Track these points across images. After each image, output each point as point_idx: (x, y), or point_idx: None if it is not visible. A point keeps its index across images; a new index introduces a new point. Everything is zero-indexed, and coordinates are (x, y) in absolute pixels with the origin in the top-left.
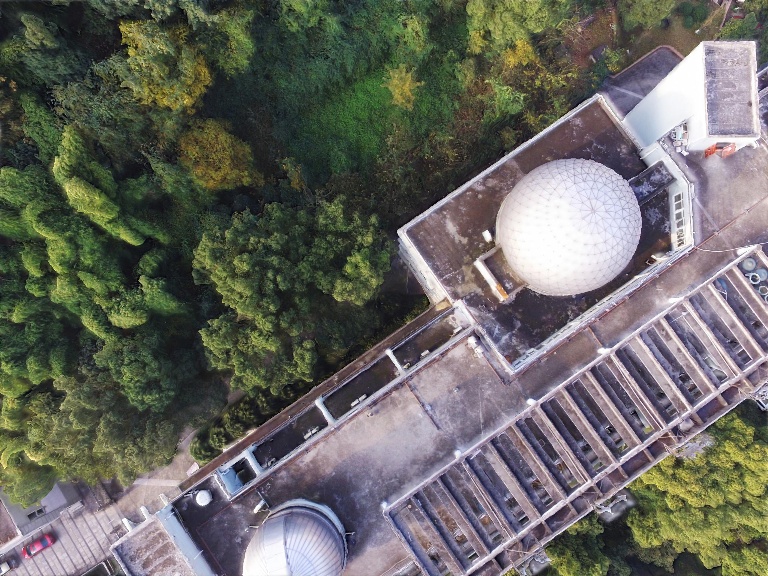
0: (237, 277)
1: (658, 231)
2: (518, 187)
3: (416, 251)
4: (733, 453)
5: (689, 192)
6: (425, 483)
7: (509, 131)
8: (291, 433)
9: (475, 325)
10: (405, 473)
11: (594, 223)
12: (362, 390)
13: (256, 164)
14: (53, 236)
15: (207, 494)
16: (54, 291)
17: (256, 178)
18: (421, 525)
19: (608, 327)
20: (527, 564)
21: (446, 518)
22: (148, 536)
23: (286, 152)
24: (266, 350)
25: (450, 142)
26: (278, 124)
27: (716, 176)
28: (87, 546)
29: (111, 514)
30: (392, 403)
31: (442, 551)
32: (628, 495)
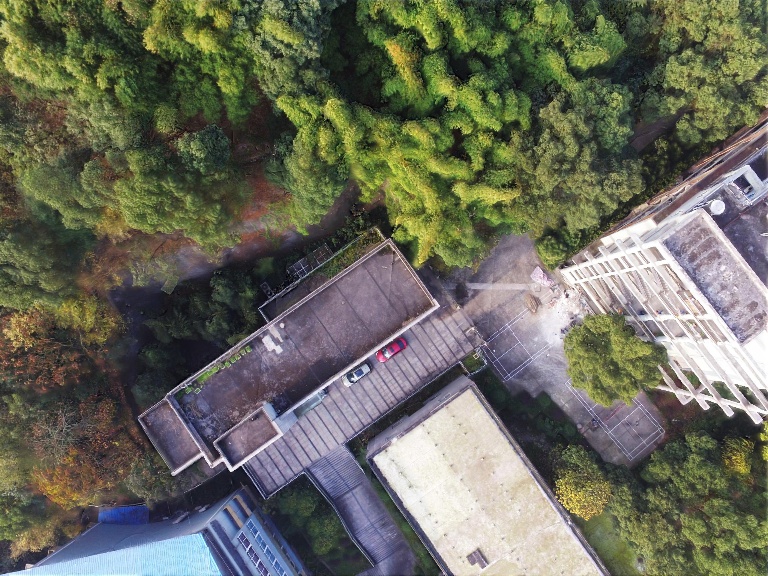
0: (718, 1)
1: None
2: None
3: None
4: None
5: None
6: None
7: None
8: (761, 163)
9: None
10: None
11: None
12: None
13: None
14: None
15: (723, 202)
16: (530, 24)
17: None
18: None
19: None
20: None
21: None
22: (690, 232)
23: None
24: (733, 82)
25: None
26: None
27: None
28: (437, 350)
29: (459, 318)
30: None
31: None
32: None
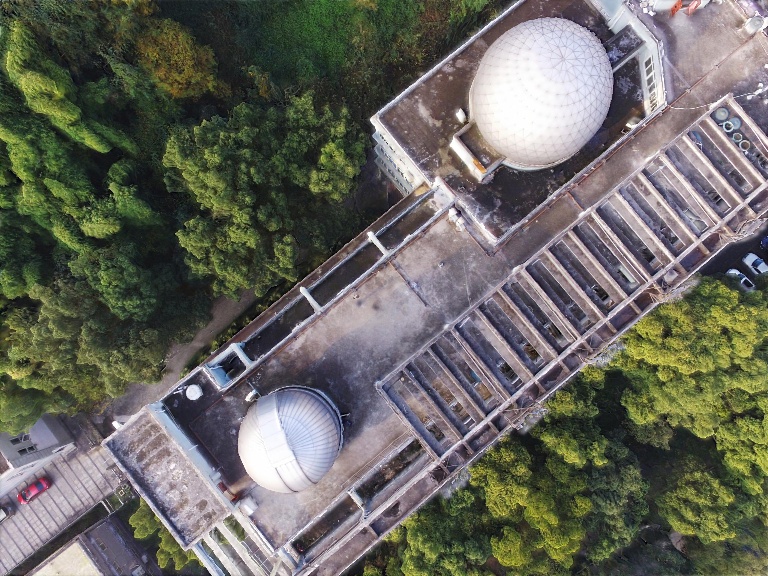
0: None
1: (631, 100)
2: (487, 52)
3: (391, 137)
4: (719, 316)
5: (658, 51)
6: (416, 354)
7: (478, 31)
8: (278, 329)
9: (455, 199)
10: (396, 351)
11: (565, 71)
12: (347, 280)
13: (222, 75)
14: (14, 139)
15: (197, 388)
16: (21, 201)
17: (223, 89)
18: (415, 396)
19: (587, 191)
20: (523, 419)
21: (440, 392)
22: (139, 430)
23: (252, 64)
24: (246, 247)
25: (419, 45)
26: (241, 32)
27: (684, 34)
28: (84, 487)
29: (106, 454)
30: (377, 283)
31: (438, 420)
32: (620, 378)
